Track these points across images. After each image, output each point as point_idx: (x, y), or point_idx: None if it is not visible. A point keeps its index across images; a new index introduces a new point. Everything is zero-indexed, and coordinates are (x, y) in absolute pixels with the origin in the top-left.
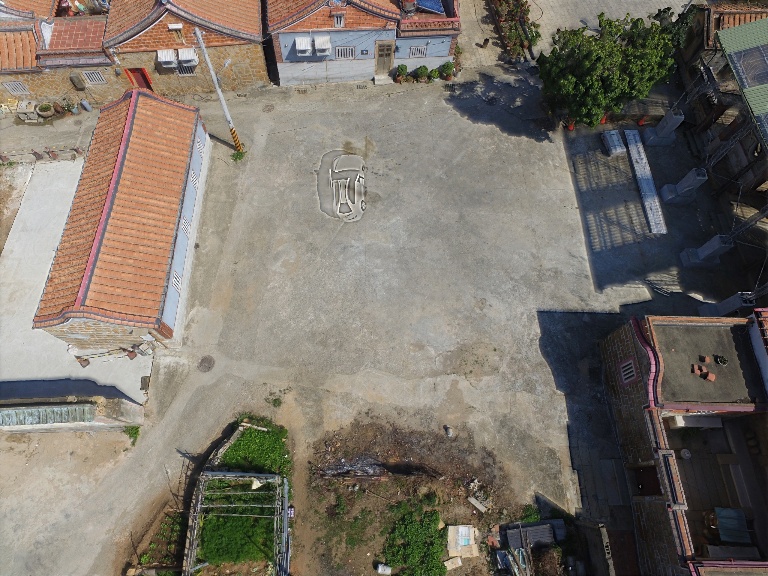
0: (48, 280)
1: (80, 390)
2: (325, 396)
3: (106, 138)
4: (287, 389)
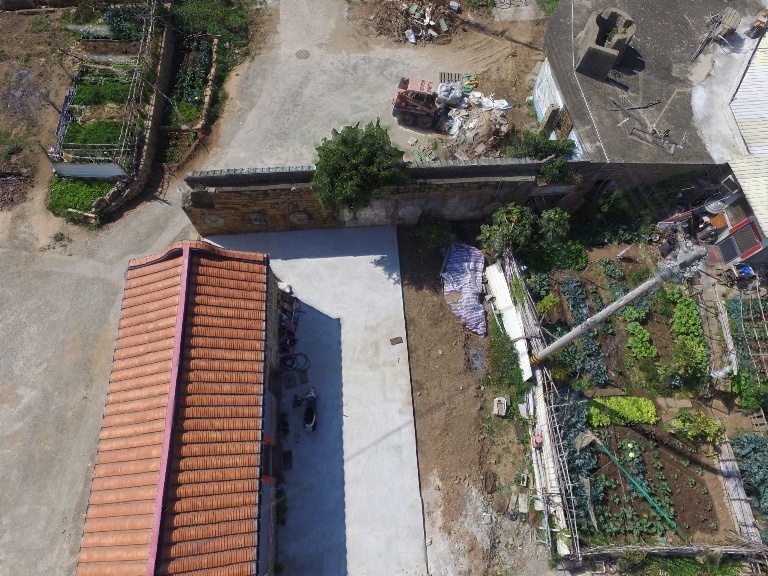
0: (264, 308)
1: (269, 250)
2: (3, 242)
3: (217, 570)
4: (46, 250)
